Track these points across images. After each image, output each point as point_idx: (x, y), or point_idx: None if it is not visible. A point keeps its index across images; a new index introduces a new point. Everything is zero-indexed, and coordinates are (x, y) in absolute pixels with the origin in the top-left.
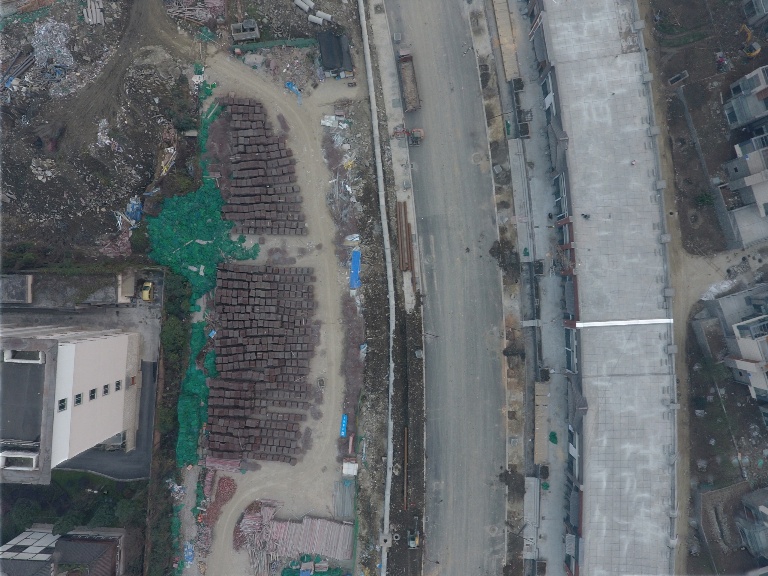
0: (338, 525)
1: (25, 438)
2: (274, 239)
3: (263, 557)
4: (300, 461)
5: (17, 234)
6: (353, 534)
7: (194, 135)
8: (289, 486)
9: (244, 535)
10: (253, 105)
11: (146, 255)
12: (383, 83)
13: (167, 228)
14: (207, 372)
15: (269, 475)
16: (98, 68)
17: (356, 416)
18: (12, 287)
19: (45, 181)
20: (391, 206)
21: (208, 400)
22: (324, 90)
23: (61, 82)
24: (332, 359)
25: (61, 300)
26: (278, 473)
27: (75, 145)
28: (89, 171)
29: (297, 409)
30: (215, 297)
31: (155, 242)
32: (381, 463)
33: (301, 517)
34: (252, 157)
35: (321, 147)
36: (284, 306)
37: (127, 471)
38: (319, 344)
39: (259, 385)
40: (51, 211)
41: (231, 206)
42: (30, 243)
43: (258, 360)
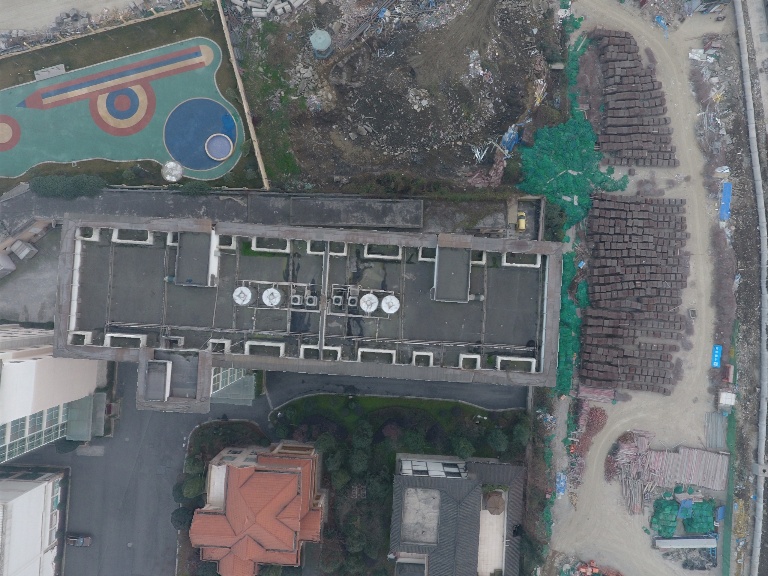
0: (715, 455)
1: (516, 343)
2: (643, 171)
3: (637, 488)
4: (671, 392)
5: (376, 166)
6: (728, 465)
7: (560, 68)
8: (660, 417)
9: (618, 465)
10: (629, 37)
11: (514, 186)
12: (751, 18)
13: (544, 157)
14: (576, 303)
15: (640, 406)
16: (467, 1)
17: (731, 346)
18: (406, 212)
19: (419, 111)
20: (761, 138)
21: (585, 329)
22: (691, 24)
23: (435, 13)
24: (702, 290)
25: (450, 226)
26: (649, 404)
27: (447, 76)
28: (459, 102)
29: (667, 340)
30: (593, 226)
31: (530, 172)
32: (754, 394)
33: (673, 448)
34: (628, 88)
35: (688, 80)
36: (658, 236)
37: (498, 401)
38: (688, 275)
39: (638, 314)
40: (410, 143)
41: (608, 136)
42: (398, 173)
43: (636, 289)
